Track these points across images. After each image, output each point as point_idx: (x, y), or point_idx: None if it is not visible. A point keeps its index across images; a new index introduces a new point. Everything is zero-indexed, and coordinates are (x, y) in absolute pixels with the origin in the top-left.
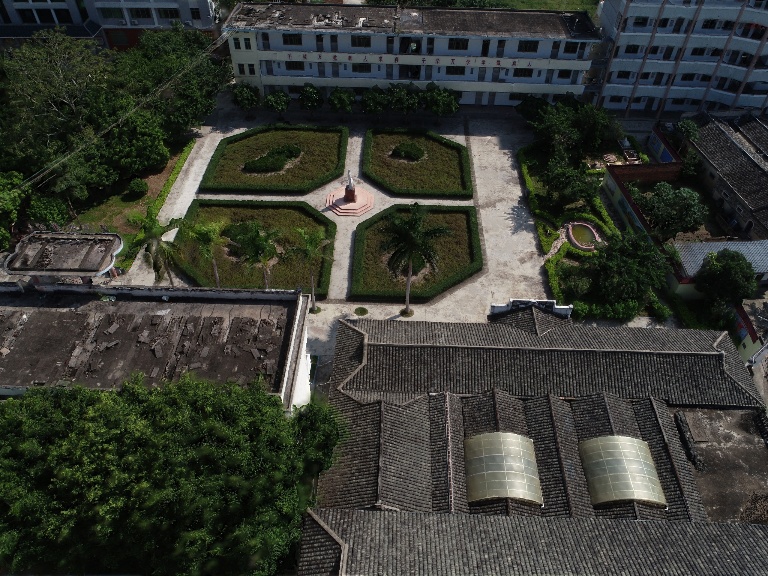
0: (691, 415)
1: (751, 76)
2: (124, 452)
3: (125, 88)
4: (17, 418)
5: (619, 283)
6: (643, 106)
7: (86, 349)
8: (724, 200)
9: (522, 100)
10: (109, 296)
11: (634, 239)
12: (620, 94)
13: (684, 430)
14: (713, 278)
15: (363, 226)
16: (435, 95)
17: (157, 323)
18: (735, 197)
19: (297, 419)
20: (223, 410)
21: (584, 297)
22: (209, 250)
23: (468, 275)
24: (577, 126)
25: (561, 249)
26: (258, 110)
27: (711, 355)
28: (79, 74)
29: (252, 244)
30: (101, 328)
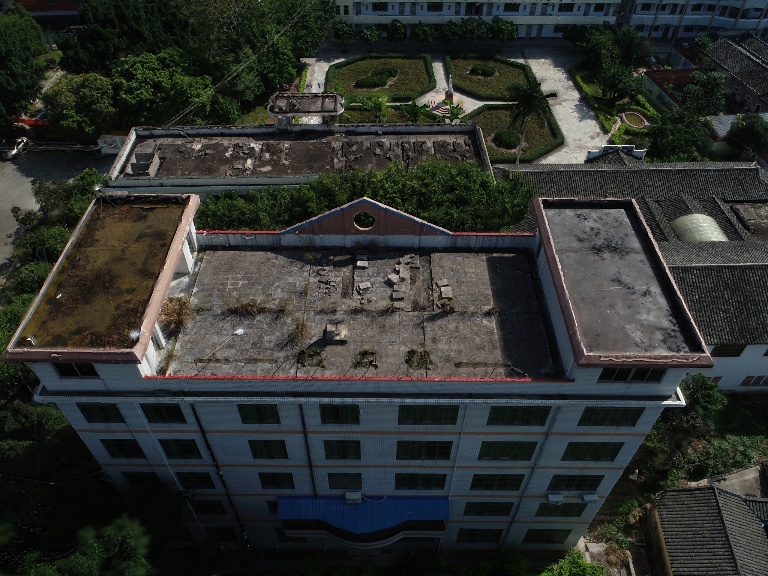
0: (741, 206)
1: (747, 3)
2: (405, 200)
3: (265, 18)
4: (328, 185)
5: (673, 140)
6: (660, 34)
7: (341, 160)
8: (736, 94)
9: (564, 32)
10: (340, 133)
11: (680, 111)
12: (644, 23)
13: (739, 212)
14: (740, 133)
15: (466, 118)
16: (501, 25)
17: (383, 145)
18: (745, 89)
19: (502, 188)
20: (465, 172)
21: (645, 156)
22: (384, 115)
23: (555, 146)
24: (617, 44)
25: (621, 128)
26: (349, 46)
27: (751, 169)
28: (239, 3)
29: (412, 112)
30: (345, 149)
